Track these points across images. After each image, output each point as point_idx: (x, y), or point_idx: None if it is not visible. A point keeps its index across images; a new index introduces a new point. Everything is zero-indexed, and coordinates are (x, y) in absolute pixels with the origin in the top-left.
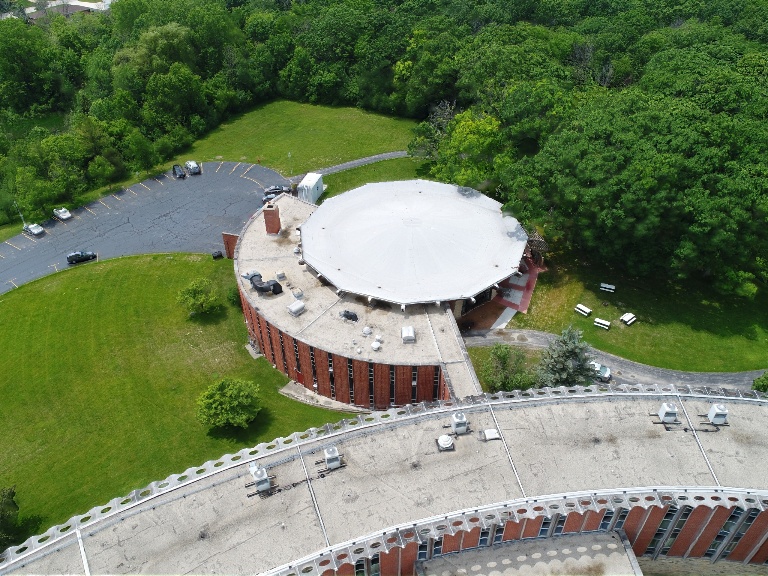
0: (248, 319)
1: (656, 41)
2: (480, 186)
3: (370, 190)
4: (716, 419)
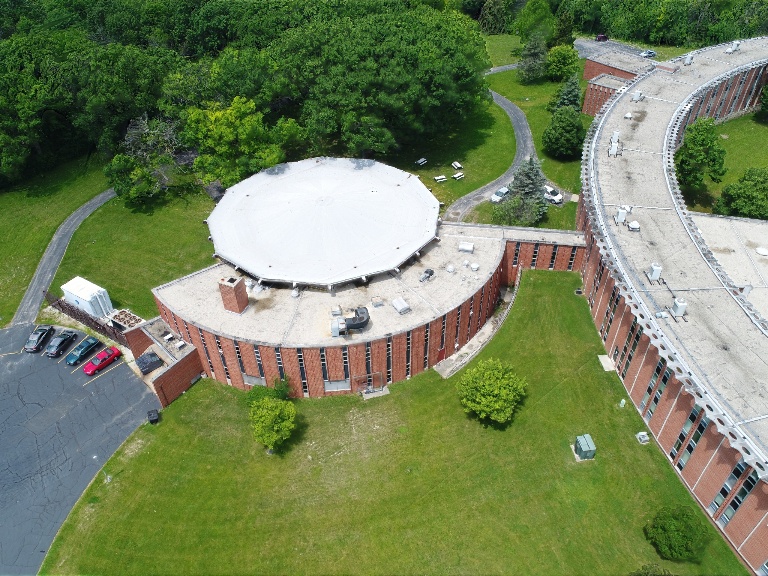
0: (354, 371)
1: (157, 8)
2: None
3: (217, 223)
4: None
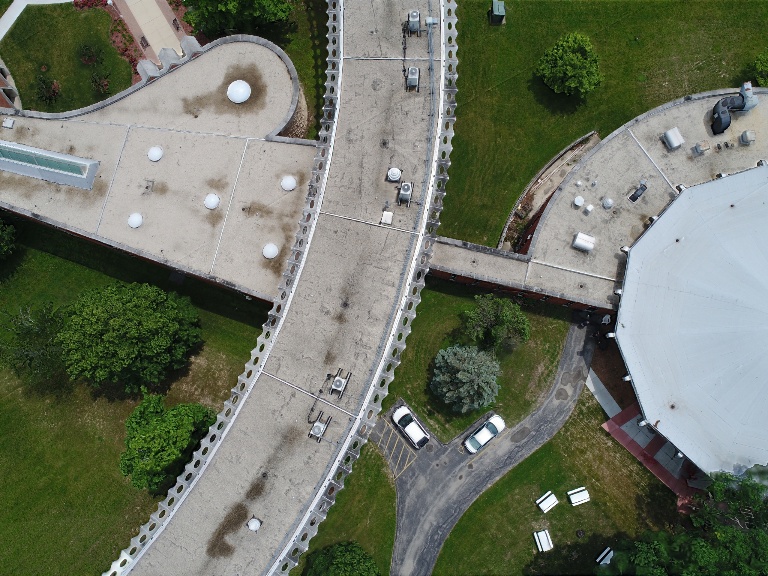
0: None
1: None
2: None
3: None
4: None
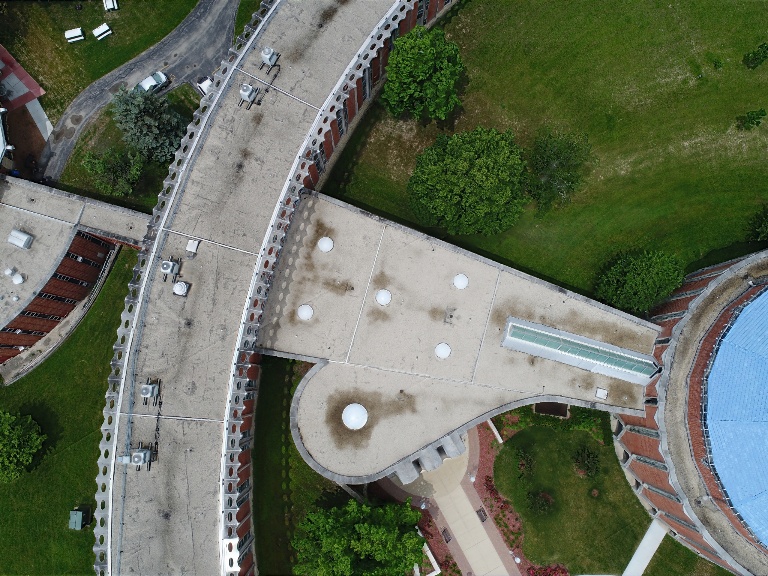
0: None
1: None
2: None
3: None
4: (271, 61)
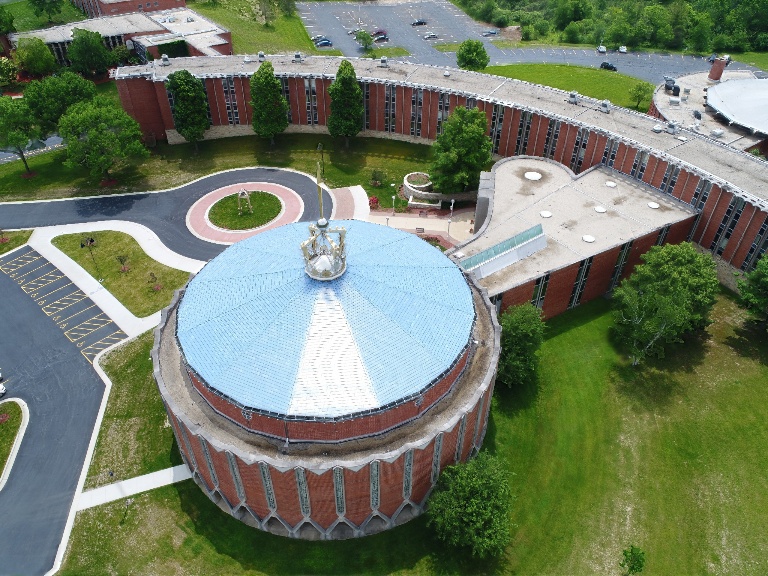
0: None
1: None
2: None
3: None
4: None
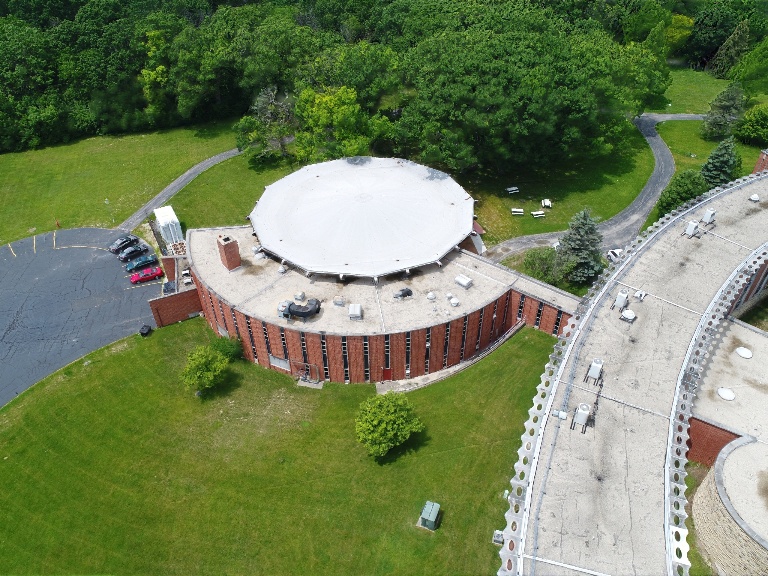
0: (292, 355)
1: None
2: (368, 151)
3: (274, 192)
4: None
